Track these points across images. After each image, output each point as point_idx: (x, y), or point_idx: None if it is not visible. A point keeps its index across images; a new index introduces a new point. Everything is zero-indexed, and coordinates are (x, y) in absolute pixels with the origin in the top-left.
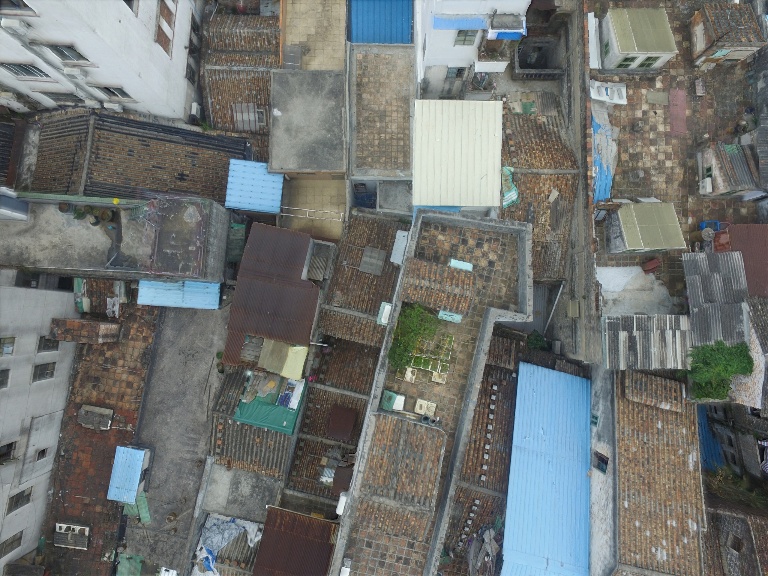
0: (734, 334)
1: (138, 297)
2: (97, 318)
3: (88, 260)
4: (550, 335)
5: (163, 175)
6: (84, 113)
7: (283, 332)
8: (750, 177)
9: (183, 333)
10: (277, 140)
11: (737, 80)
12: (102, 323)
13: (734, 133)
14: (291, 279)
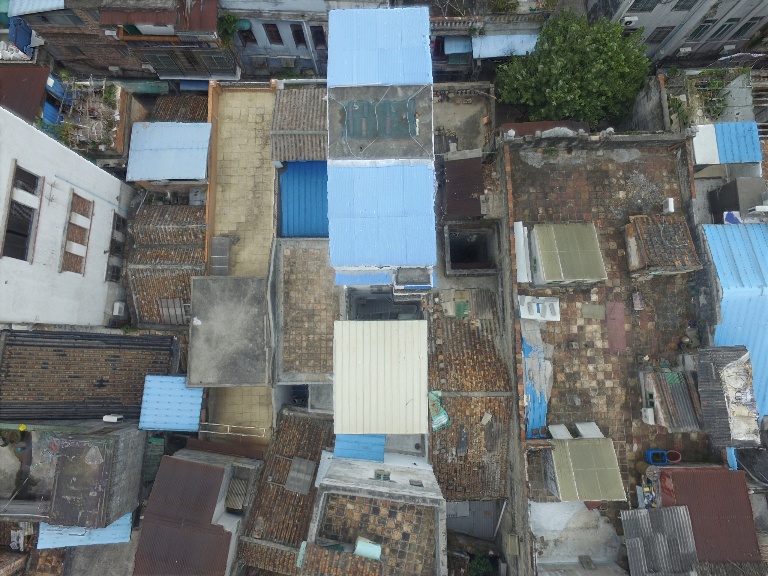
0: None
1: (38, 540)
2: (3, 546)
3: None
4: (499, 544)
5: (80, 384)
6: None
7: None
8: (693, 416)
9: (96, 560)
10: (196, 351)
11: (678, 290)
12: (3, 562)
13: (678, 350)
14: (200, 524)
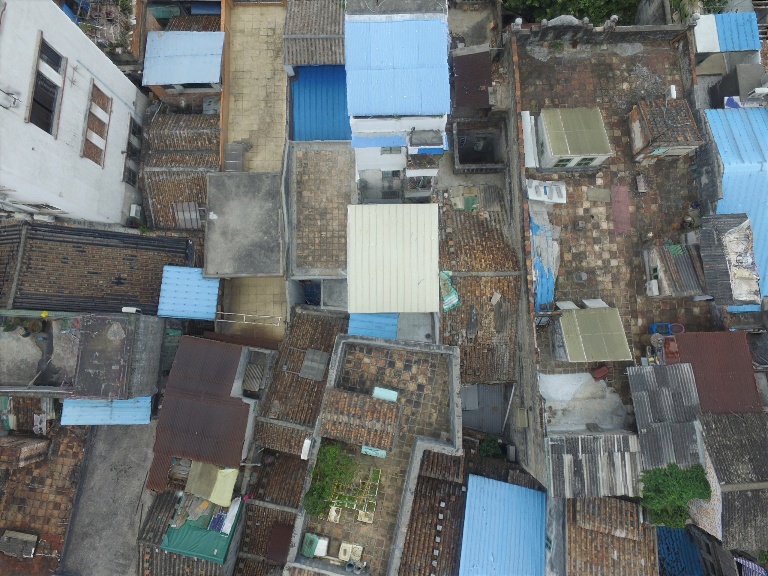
0: (688, 456)
1: (62, 417)
2: (26, 433)
3: (17, 373)
4: (507, 435)
5: (99, 280)
6: (17, 223)
7: (212, 453)
8: (696, 282)
9: (116, 447)
10: (213, 244)
11: (680, 174)
12: (26, 443)
13: (680, 229)
14: (219, 397)
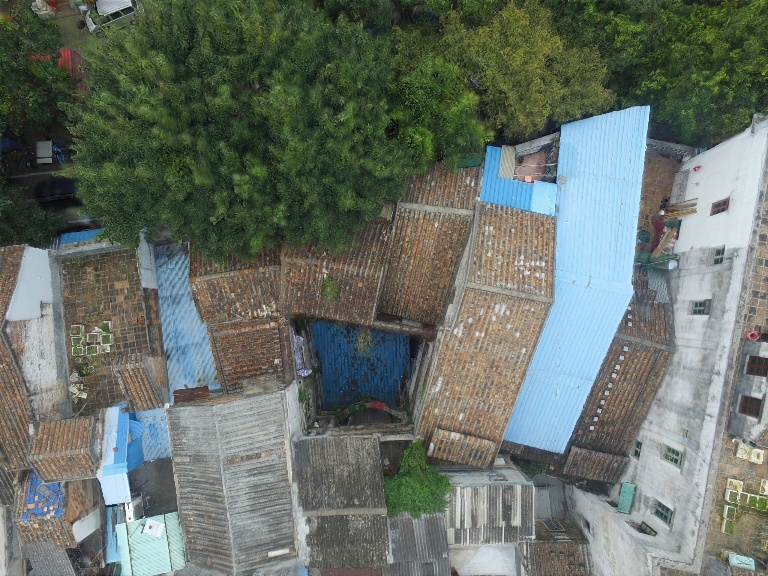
0: (401, 527)
1: None
2: None
3: None
4: None
5: None
6: None
7: None
8: None
9: None
10: None
11: None
12: None
13: None
14: None
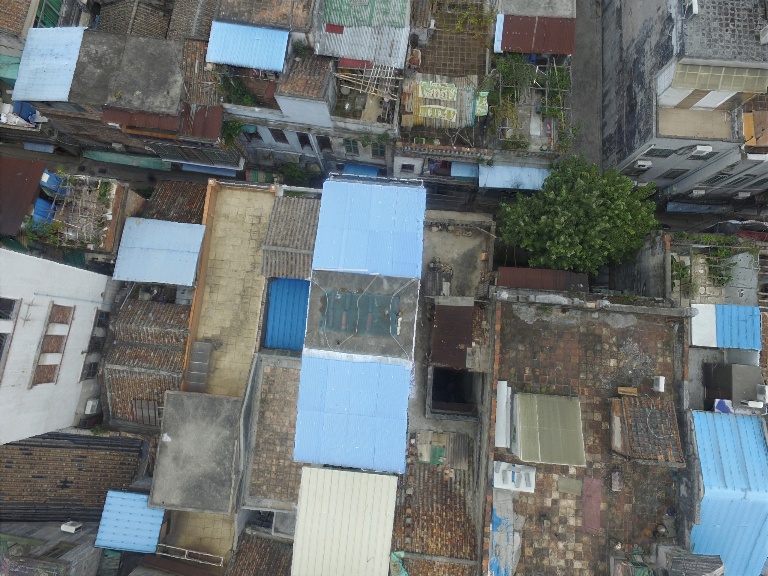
0: None
1: None
2: None
3: None
4: None
5: (43, 484)
6: None
7: None
8: None
9: None
10: (162, 469)
11: (659, 473)
12: None
13: (652, 538)
14: None
